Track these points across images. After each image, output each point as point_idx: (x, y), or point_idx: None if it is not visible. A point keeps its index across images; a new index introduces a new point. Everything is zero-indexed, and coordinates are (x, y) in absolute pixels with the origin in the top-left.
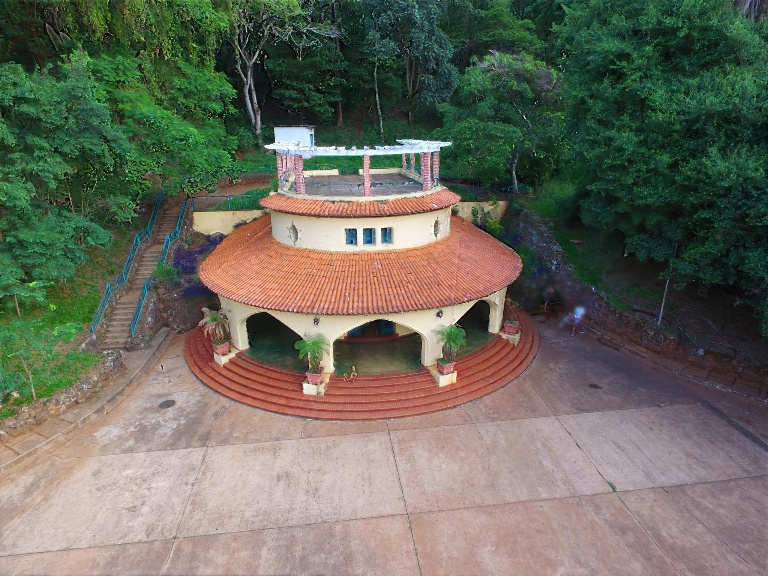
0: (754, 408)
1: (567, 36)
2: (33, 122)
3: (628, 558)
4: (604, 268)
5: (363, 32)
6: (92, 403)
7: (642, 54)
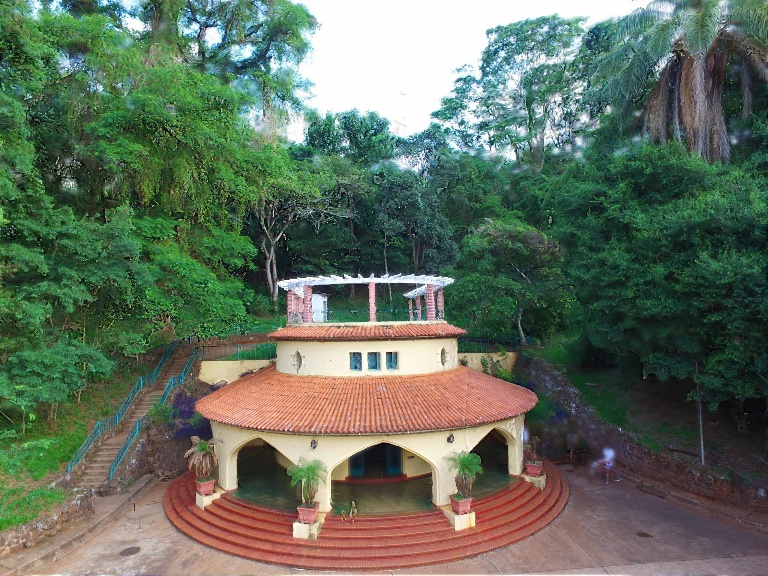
0: None
1: (550, 197)
2: (69, 258)
3: None
4: (628, 409)
5: (374, 215)
6: (42, 547)
7: (617, 190)
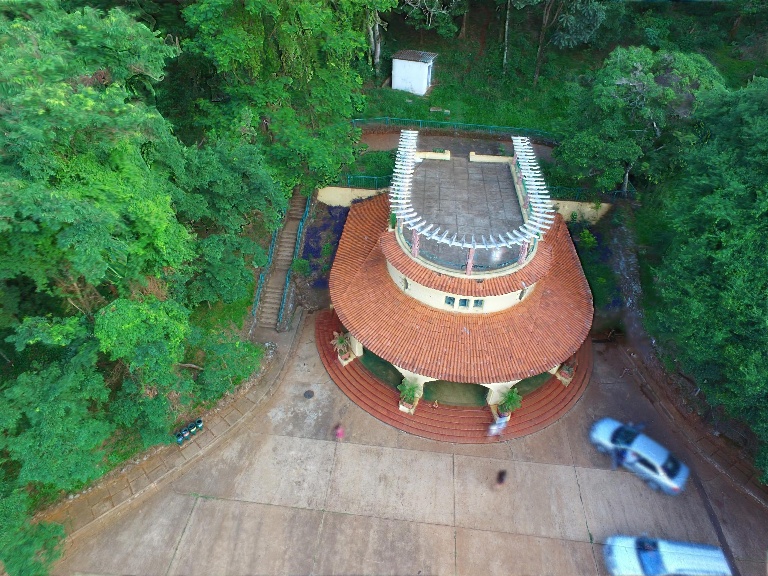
0: (734, 494)
1: (707, 116)
2: None
3: None
4: None
5: None
6: (263, 386)
7: (742, 235)
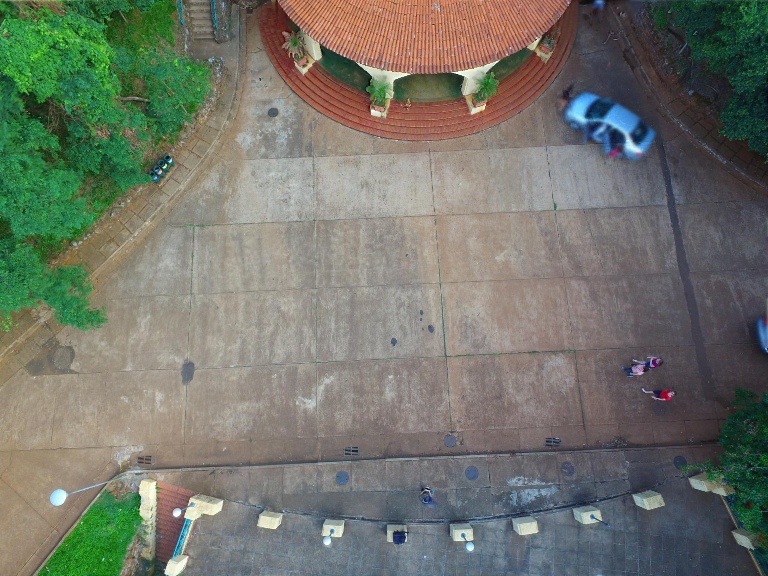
0: (690, 149)
1: None
2: None
3: (541, 248)
4: None
5: None
6: (221, 111)
7: None
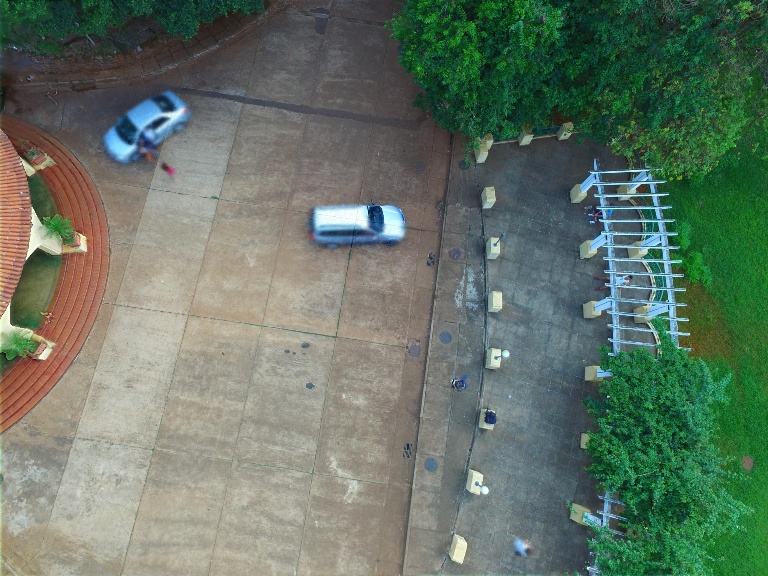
0: (196, 68)
1: None
2: None
3: (253, 222)
4: None
5: None
6: None
7: None
